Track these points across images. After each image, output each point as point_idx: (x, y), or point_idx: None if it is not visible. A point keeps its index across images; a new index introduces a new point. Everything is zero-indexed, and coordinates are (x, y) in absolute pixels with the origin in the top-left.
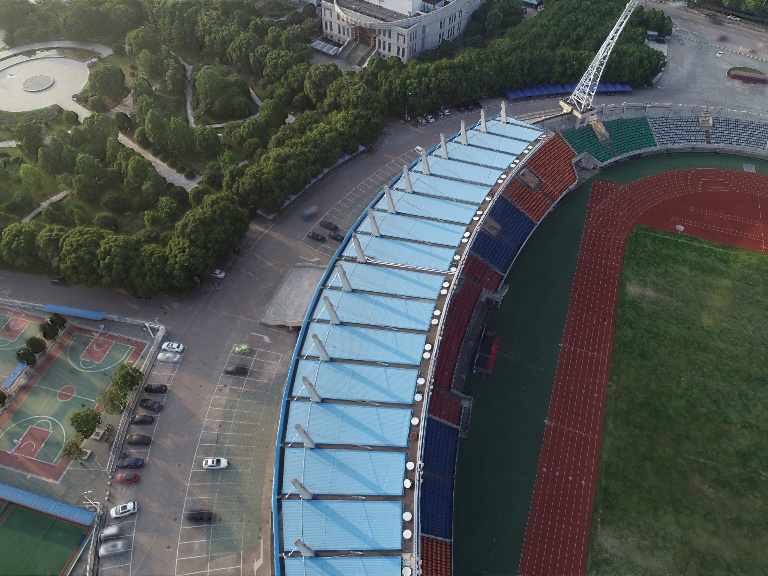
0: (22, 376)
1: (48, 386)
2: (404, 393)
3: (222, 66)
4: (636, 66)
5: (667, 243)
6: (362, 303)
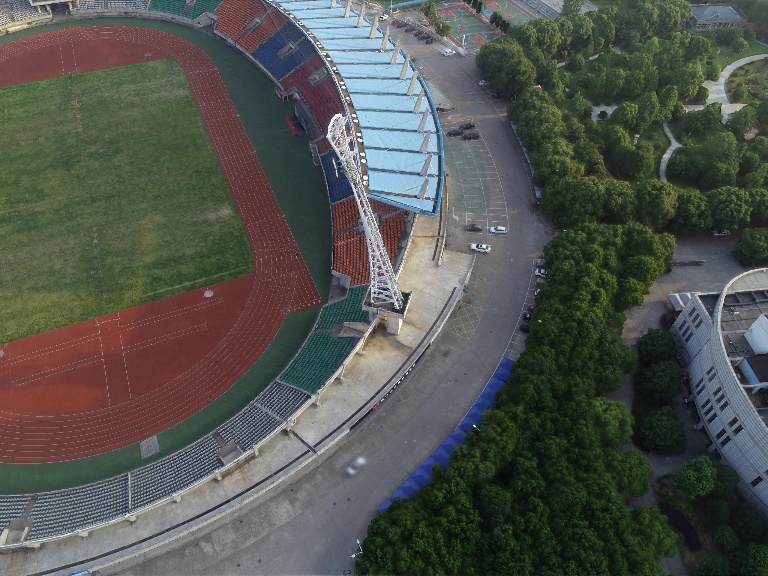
0: (488, 21)
1: (473, 25)
2: (296, 13)
3: (762, 177)
4: (394, 512)
5: (215, 269)
6: (356, 34)
